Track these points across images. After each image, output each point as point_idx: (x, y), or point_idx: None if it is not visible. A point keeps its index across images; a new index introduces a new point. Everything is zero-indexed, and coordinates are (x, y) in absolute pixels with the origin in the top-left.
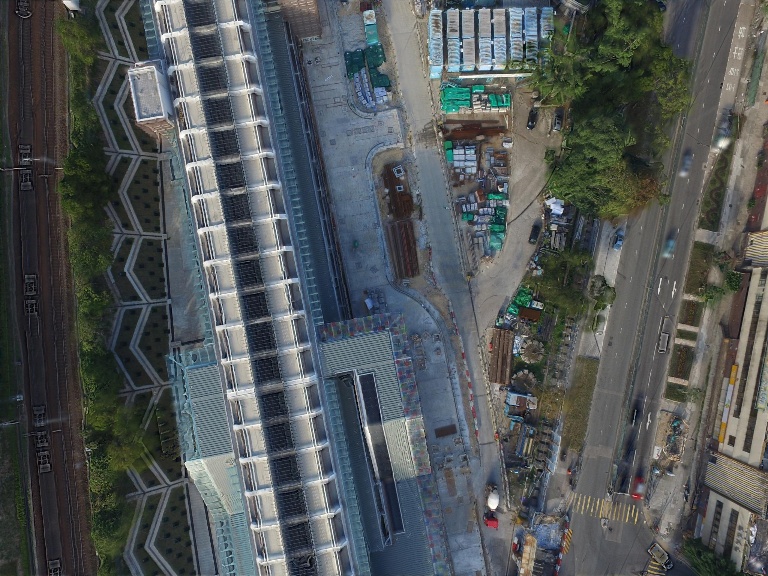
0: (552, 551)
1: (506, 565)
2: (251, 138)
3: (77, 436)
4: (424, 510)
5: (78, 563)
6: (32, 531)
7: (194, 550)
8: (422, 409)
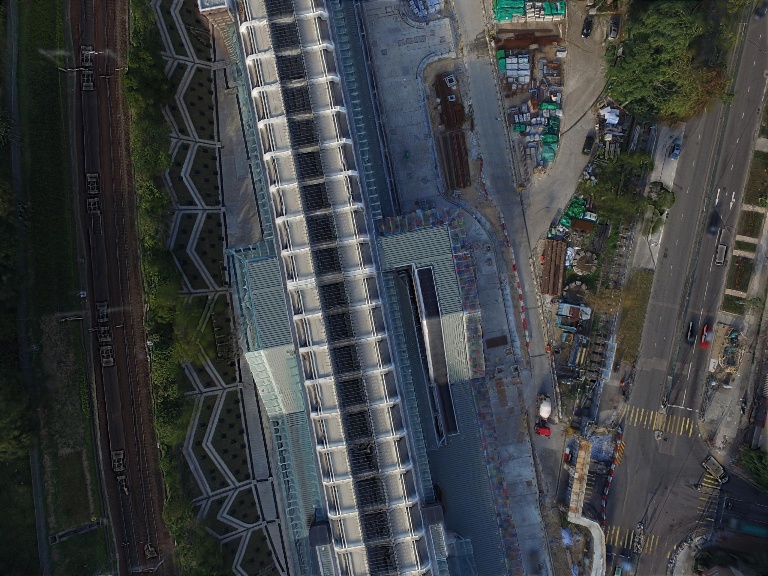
0: (604, 463)
1: (557, 475)
2: (311, 30)
3: (138, 332)
4: (478, 413)
5: (140, 455)
6: (96, 423)
7: (248, 453)
8: None
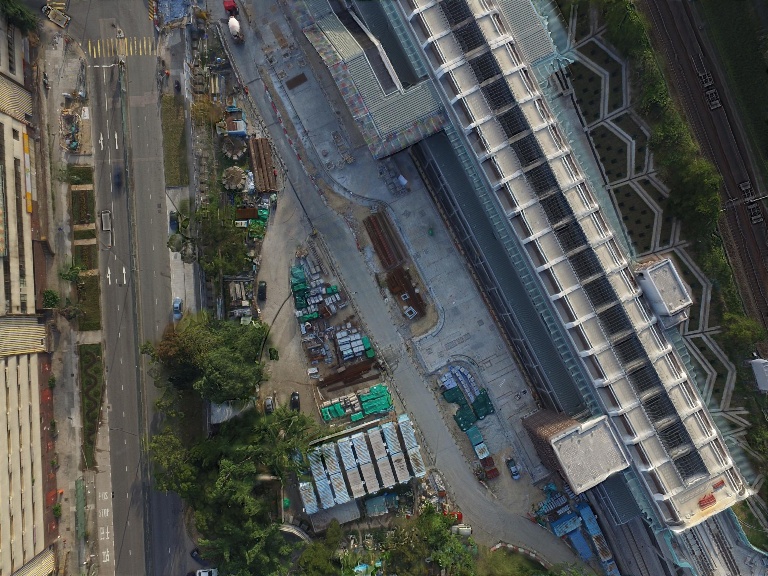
0: None
1: None
2: (563, 279)
3: None
4: None
5: None
6: None
7: None
8: (325, 96)
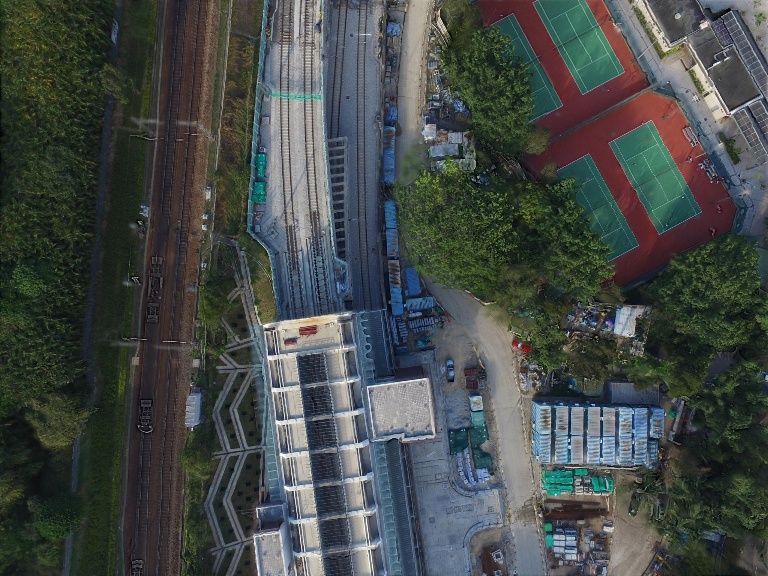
0: None
1: None
2: None
3: None
4: None
5: None
6: None
7: None
8: None
